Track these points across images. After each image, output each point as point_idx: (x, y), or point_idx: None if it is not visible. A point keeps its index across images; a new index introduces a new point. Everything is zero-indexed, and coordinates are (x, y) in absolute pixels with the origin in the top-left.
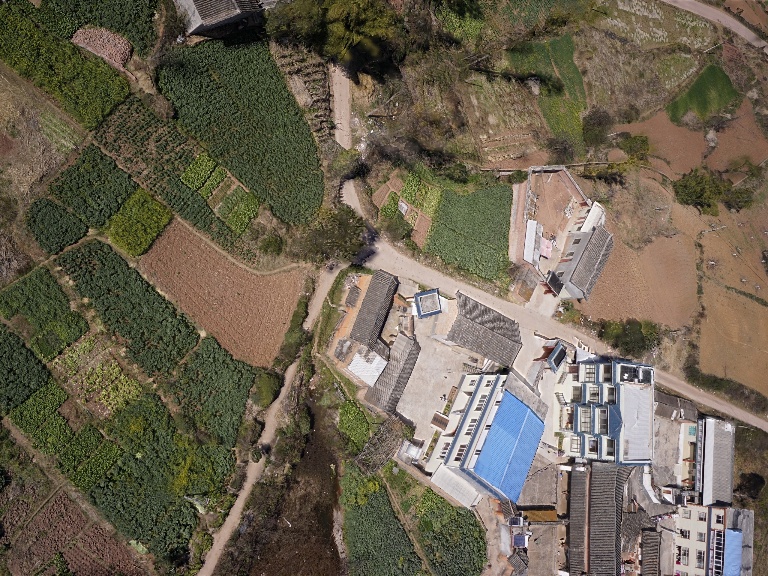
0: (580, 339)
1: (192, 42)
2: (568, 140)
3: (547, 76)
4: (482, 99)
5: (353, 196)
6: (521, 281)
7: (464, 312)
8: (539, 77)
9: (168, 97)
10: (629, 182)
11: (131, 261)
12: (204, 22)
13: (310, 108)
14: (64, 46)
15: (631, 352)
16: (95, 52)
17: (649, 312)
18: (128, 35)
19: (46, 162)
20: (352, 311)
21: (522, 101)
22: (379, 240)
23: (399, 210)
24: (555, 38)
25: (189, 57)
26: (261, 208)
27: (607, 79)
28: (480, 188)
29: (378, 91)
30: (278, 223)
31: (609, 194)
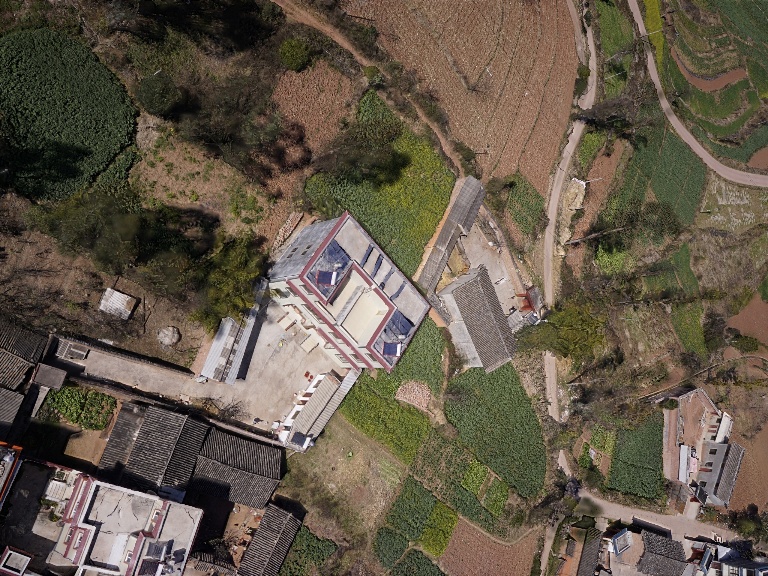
0: (715, 532)
1: (464, 370)
2: (695, 351)
3: (674, 290)
4: (632, 330)
5: (562, 457)
6: (676, 496)
7: (649, 547)
8: (669, 294)
9: (452, 421)
10: (740, 376)
11: (434, 560)
12: (486, 371)
13: (535, 395)
14: (391, 404)
15: (752, 534)
16: (409, 402)
17: (762, 494)
18: (428, 382)
19: (384, 499)
20: (570, 560)
21: (659, 322)
22: (581, 490)
23: (590, 457)
24: (676, 251)
25: (463, 384)
26: (510, 492)
27: (716, 278)
28: (641, 419)
29: (572, 359)
30: (521, 501)
31: (727, 391)
